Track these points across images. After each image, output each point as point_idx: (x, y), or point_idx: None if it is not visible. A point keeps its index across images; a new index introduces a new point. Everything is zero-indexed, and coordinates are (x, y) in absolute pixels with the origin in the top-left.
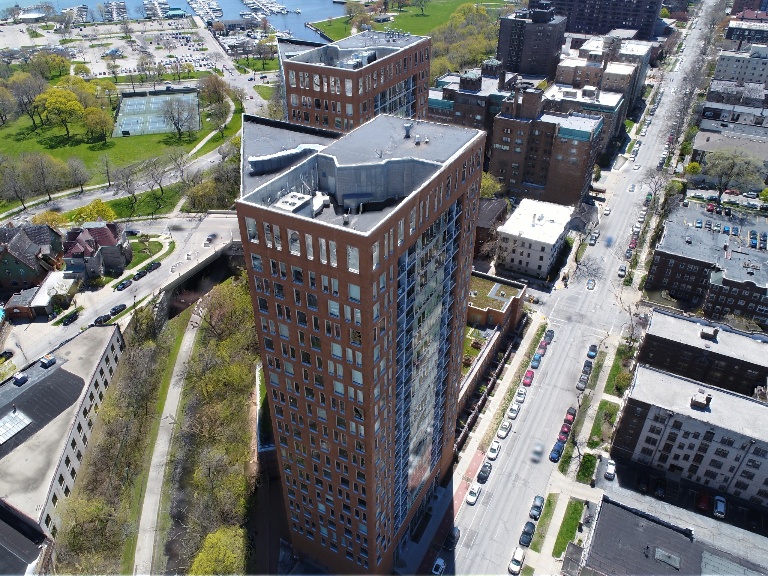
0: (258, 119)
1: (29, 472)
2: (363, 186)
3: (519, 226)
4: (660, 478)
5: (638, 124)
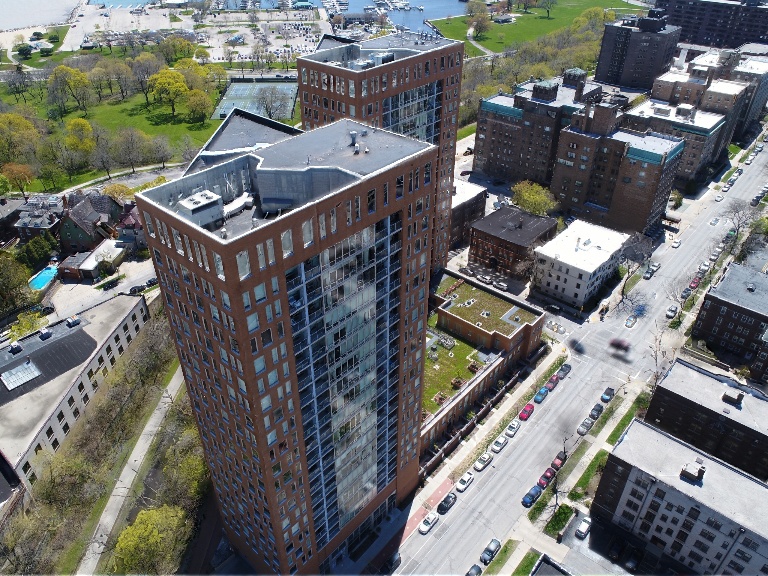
0: (247, 114)
1: (24, 420)
2: (284, 191)
3: (561, 249)
4: (637, 548)
5: (745, 150)
